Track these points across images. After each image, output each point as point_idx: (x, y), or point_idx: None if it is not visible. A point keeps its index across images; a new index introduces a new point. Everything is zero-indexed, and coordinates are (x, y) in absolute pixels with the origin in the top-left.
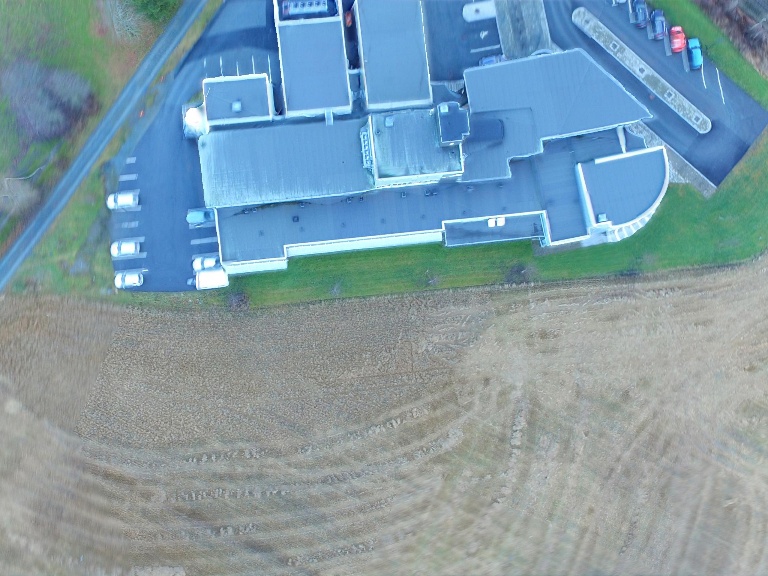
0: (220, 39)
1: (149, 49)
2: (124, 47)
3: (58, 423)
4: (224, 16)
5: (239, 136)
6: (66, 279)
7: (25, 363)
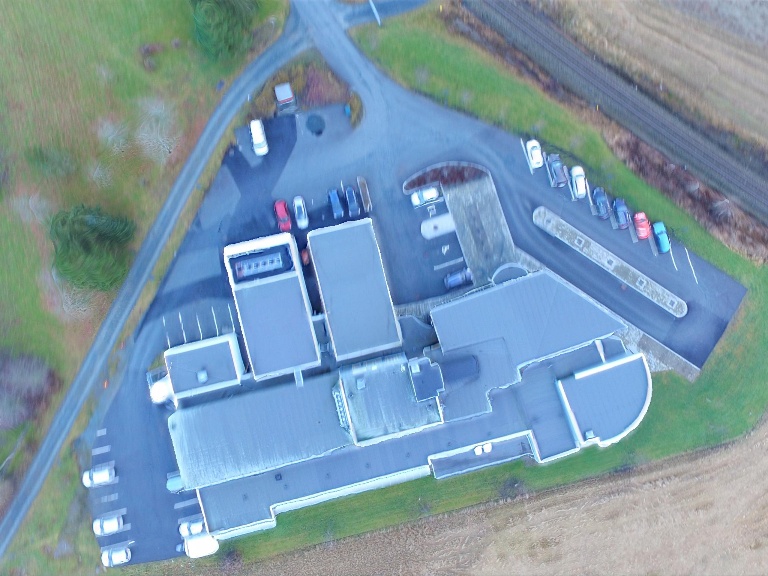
0: (176, 294)
1: (104, 316)
2: (78, 319)
3: None
4: (177, 270)
5: (209, 411)
6: (51, 564)
7: None
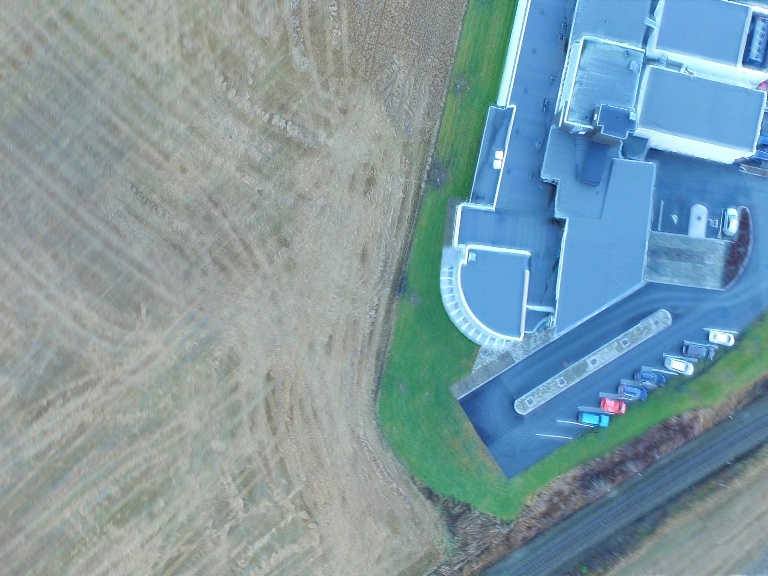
0: None
1: None
2: None
3: None
4: None
5: None
6: None
7: None
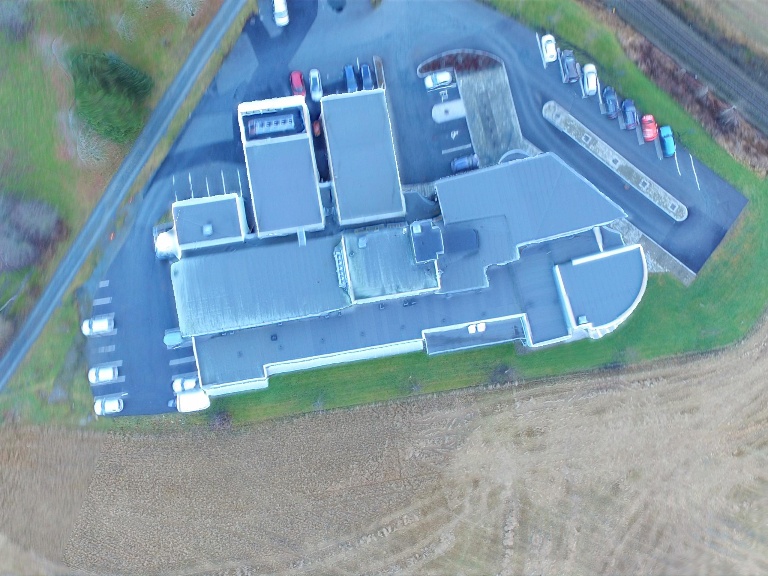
0: (188, 155)
1: (116, 170)
2: (90, 170)
3: (45, 554)
4: (190, 132)
5: (211, 262)
6: (45, 408)
7: (8, 496)
